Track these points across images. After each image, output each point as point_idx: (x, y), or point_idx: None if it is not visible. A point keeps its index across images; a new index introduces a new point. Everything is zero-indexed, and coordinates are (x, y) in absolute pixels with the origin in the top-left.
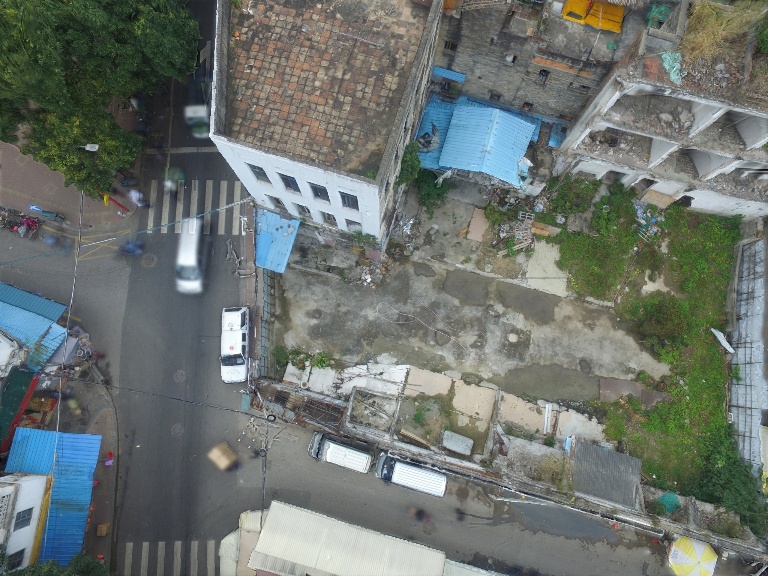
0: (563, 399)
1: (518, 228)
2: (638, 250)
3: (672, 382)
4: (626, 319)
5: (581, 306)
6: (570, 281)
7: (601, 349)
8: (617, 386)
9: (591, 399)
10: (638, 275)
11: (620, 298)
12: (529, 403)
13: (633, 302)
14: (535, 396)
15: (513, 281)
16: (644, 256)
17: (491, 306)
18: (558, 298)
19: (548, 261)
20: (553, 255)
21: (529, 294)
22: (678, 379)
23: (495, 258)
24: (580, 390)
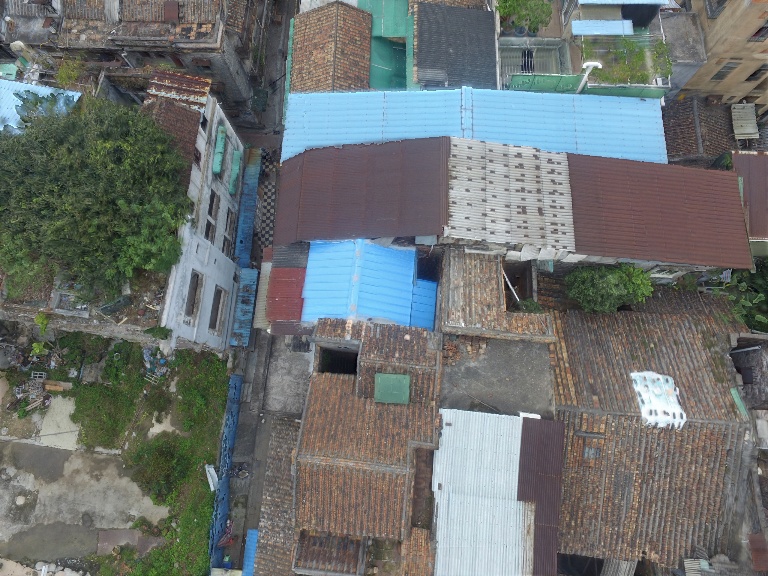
0: (62, 558)
1: (32, 387)
2: (146, 393)
3: (165, 526)
4: (130, 465)
5: (90, 457)
6: (81, 433)
7: (104, 500)
8: (115, 536)
9: (88, 554)
10: (146, 418)
11: (127, 444)
12: (26, 567)
13: (139, 446)
14: (35, 559)
15: (27, 441)
16: (152, 398)
17: (4, 470)
18: (69, 452)
19: (63, 415)
20: (68, 409)
21: (42, 452)
22: (171, 522)
23: (12, 420)
24: (80, 546)
